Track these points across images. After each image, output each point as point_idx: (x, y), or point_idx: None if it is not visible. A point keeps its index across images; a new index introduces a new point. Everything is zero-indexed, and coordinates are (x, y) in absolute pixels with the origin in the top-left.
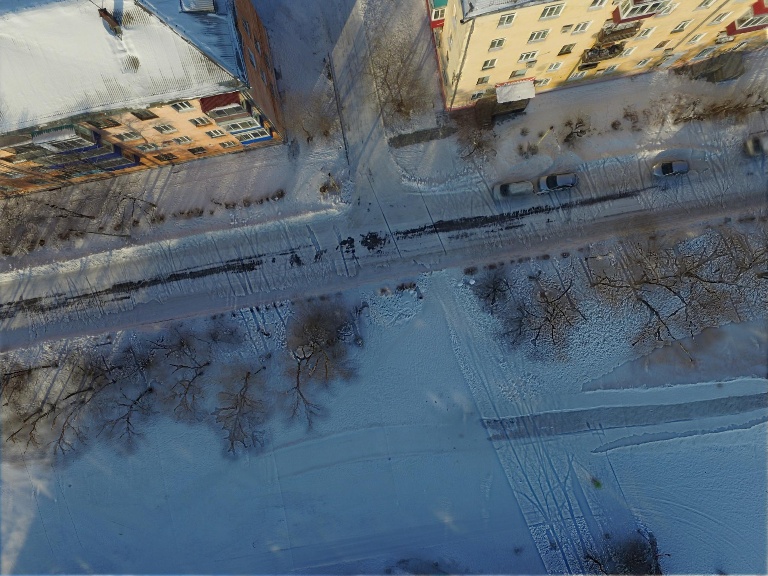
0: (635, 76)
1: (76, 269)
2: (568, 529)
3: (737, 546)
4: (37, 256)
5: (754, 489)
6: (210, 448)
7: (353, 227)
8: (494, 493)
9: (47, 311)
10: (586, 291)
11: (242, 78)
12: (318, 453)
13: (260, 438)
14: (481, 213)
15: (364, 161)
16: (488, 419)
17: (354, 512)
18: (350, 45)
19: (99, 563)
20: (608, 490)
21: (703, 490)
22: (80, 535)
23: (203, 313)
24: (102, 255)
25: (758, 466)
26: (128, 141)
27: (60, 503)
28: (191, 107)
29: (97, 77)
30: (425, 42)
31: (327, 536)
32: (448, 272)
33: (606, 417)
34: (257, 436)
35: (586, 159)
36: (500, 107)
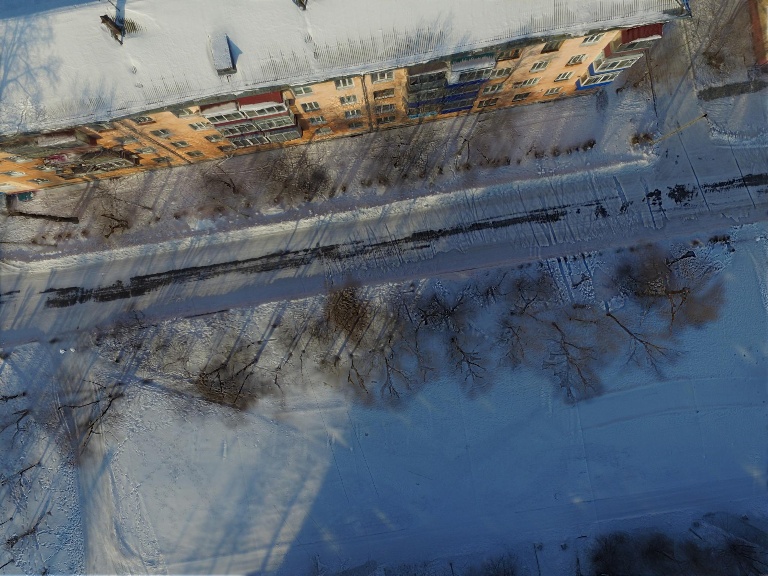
0: None
1: (376, 216)
2: None
3: None
4: (337, 203)
5: None
6: (513, 398)
7: (660, 179)
8: None
9: (344, 258)
10: None
11: (686, 6)
12: (623, 405)
13: (593, 385)
14: None
15: (672, 113)
16: None
17: (659, 465)
18: None
19: (396, 513)
20: None
21: None
22: (377, 484)
23: (507, 263)
24: (405, 202)
25: None
26: (492, 79)
27: (356, 452)
28: (594, 41)
29: (549, 0)
30: None
31: (632, 488)
32: (759, 226)
33: None
34: (588, 383)
35: None
36: None
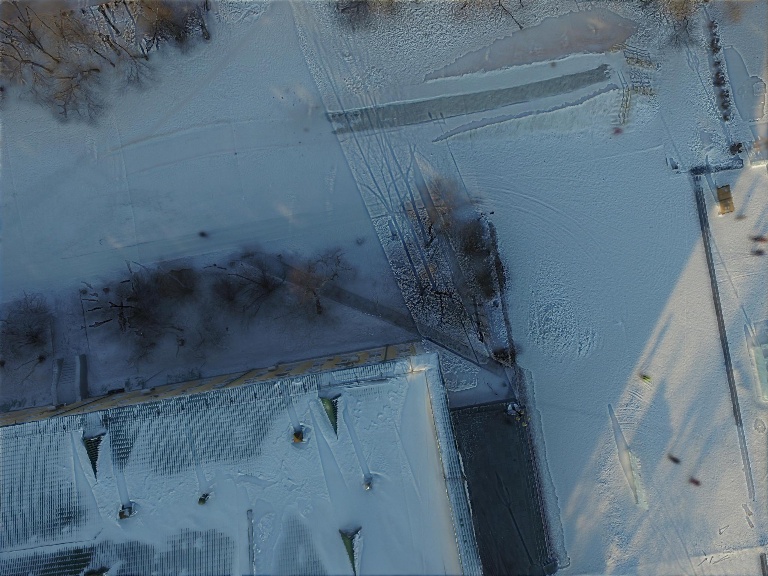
0: None
1: None
2: (410, 220)
3: (575, 234)
4: None
5: (592, 177)
6: (59, 146)
7: None
8: (338, 186)
9: None
10: None
11: None
12: (166, 150)
13: (95, 108)
14: None
15: None
16: (333, 113)
17: (201, 208)
18: None
19: None
20: (449, 180)
21: (542, 179)
22: None
23: (54, 12)
24: None
25: (596, 154)
26: None
27: None
28: None
29: None
30: None
31: (173, 232)
32: None
33: (447, 106)
34: (93, 107)
35: None
36: None
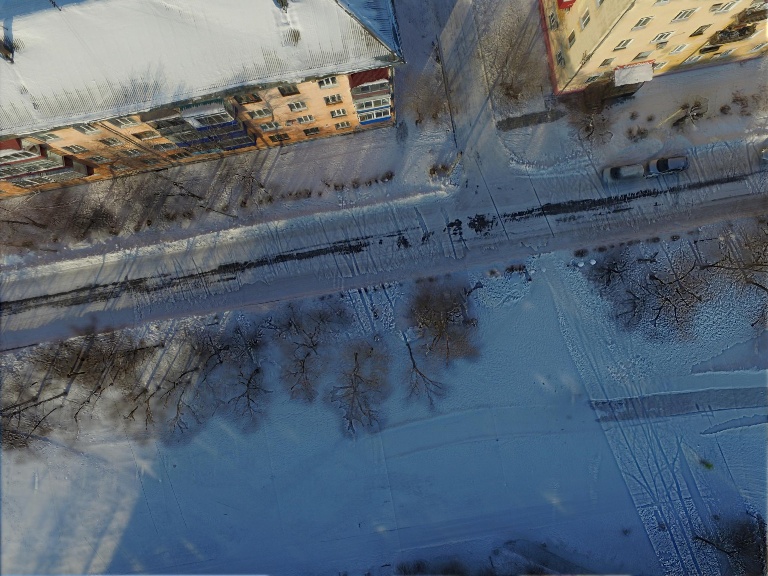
0: (744, 61)
1: (182, 250)
2: (676, 510)
3: None
4: (143, 236)
5: None
6: (317, 429)
7: (461, 209)
8: (602, 474)
9: (152, 291)
10: (695, 274)
11: (398, 53)
12: (425, 434)
13: (377, 417)
14: (589, 196)
15: (472, 144)
16: (596, 401)
17: (461, 493)
18: (458, 29)
19: (204, 543)
20: (716, 472)
21: None
22: (185, 515)
23: (310, 294)
24: (209, 236)
25: None
26: (257, 119)
27: (165, 483)
28: (333, 83)
29: (257, 50)
30: (534, 26)
31: (434, 517)
32: (556, 254)
33: (715, 399)
34: (374, 415)
35: (695, 143)
36: (611, 91)
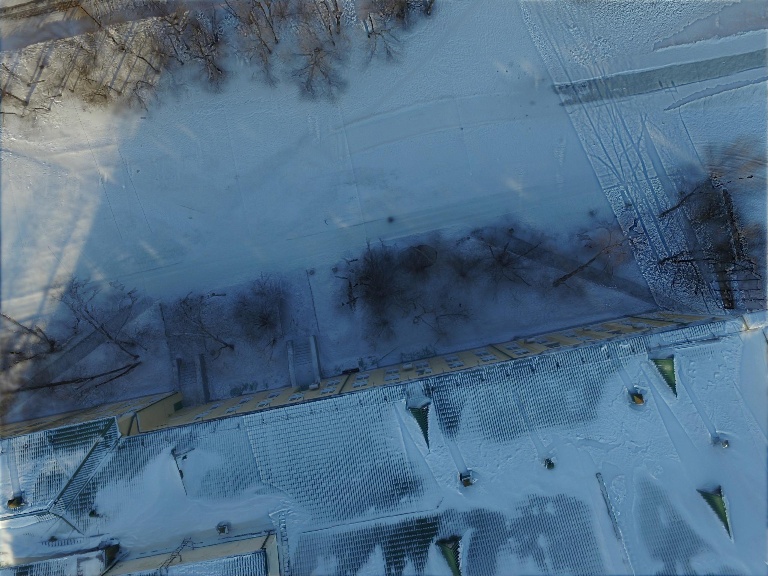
0: None
1: None
2: (643, 190)
3: None
4: None
5: None
6: (280, 126)
7: None
8: (567, 158)
9: None
10: None
11: None
12: (389, 128)
13: (337, 84)
14: None
15: None
16: (560, 85)
17: (427, 185)
18: None
19: (169, 247)
20: (682, 149)
21: None
22: (149, 219)
23: None
24: None
25: None
26: None
27: (128, 189)
28: None
29: None
30: None
31: (400, 209)
32: None
33: (678, 74)
34: None
35: None
36: None
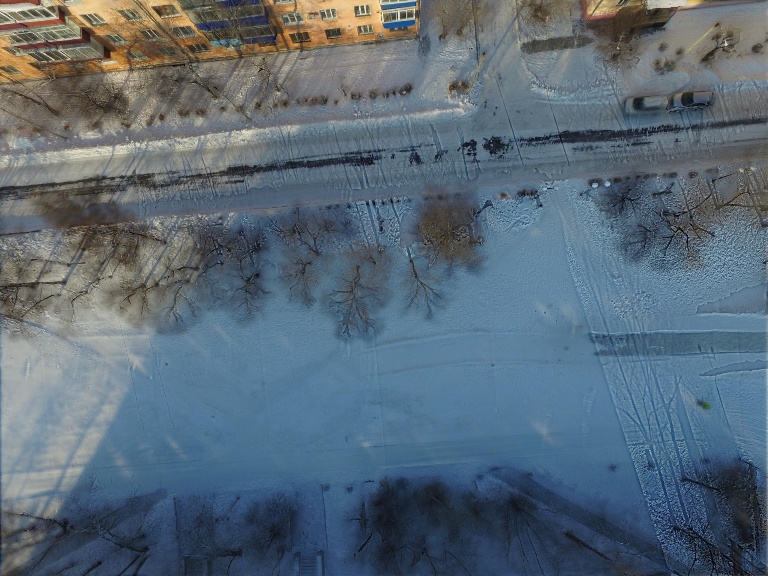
0: None
1: (192, 148)
2: (668, 451)
3: None
4: (155, 131)
5: None
6: (312, 338)
7: (477, 130)
8: (596, 409)
9: (159, 188)
10: (710, 213)
11: None
12: (420, 353)
13: (374, 325)
14: (609, 127)
15: (494, 64)
16: (597, 334)
17: (451, 415)
18: None
19: (189, 443)
20: (713, 415)
21: None
22: (173, 414)
23: (317, 203)
24: (221, 135)
25: None
26: (279, 5)
27: (155, 380)
28: None
29: None
30: None
31: (422, 437)
32: (570, 183)
33: (719, 341)
34: (371, 323)
35: (723, 80)
36: (642, 18)
